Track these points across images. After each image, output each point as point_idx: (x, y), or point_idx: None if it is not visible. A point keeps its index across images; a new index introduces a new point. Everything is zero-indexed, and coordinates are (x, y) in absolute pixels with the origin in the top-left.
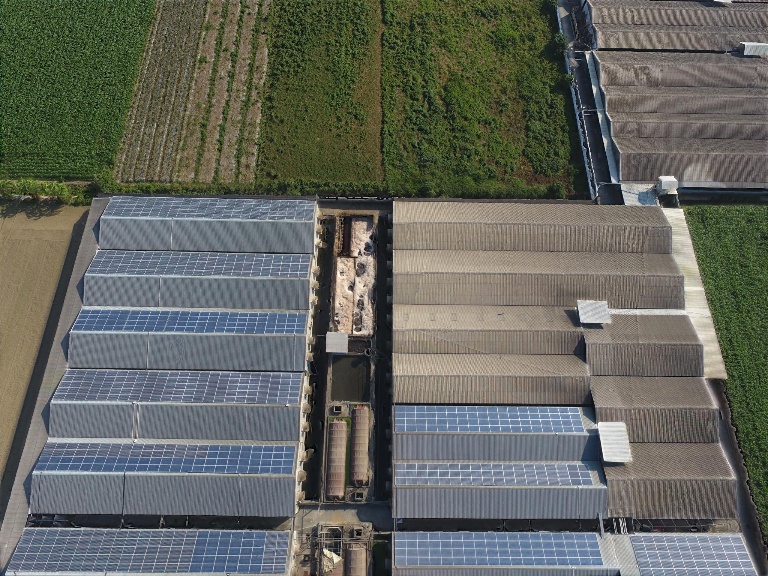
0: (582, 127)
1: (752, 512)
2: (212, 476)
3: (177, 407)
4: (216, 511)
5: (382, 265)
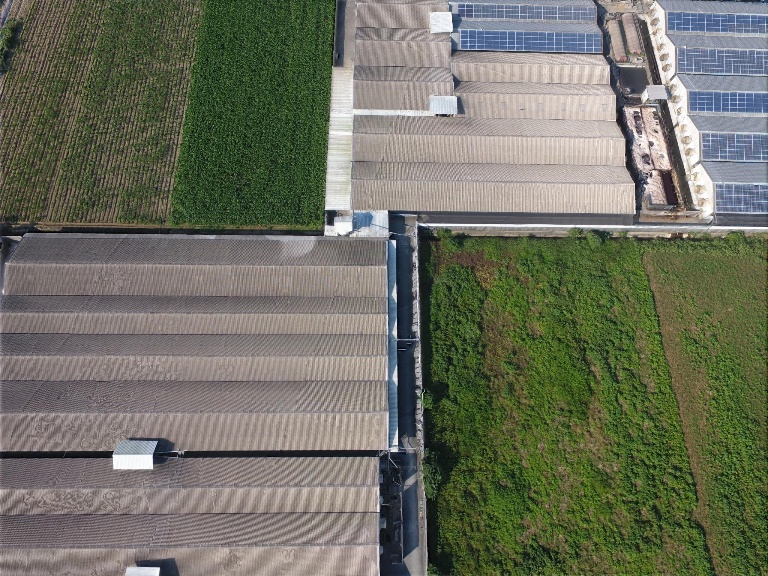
0: (412, 329)
1: (337, 4)
2: (721, 12)
3: (764, 48)
4: (707, 2)
5: (626, 166)
